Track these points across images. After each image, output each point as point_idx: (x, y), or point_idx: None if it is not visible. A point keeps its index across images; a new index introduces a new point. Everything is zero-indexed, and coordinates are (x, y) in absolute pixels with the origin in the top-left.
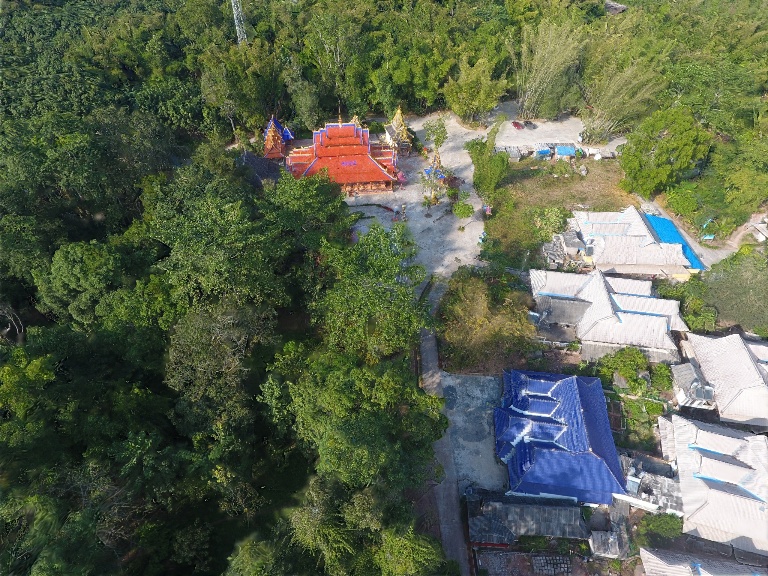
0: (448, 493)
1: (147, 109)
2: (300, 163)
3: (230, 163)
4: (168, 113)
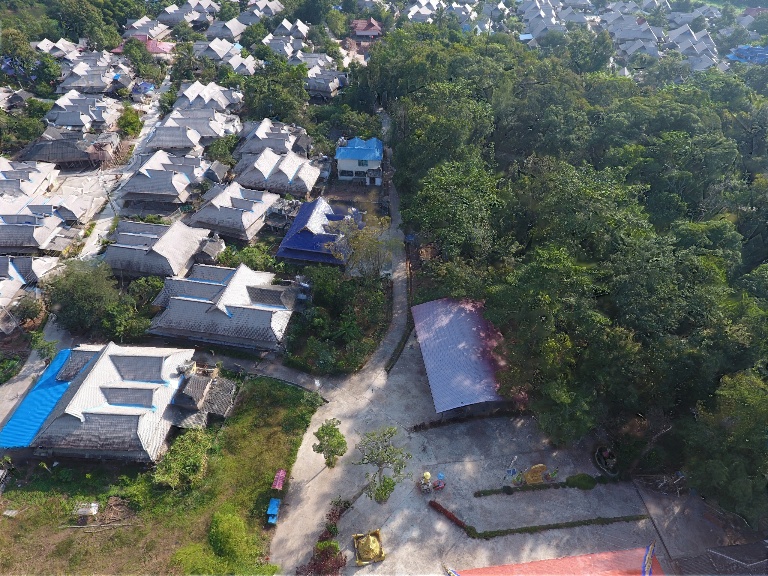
0: (396, 224)
1: None
2: None
3: None
4: None
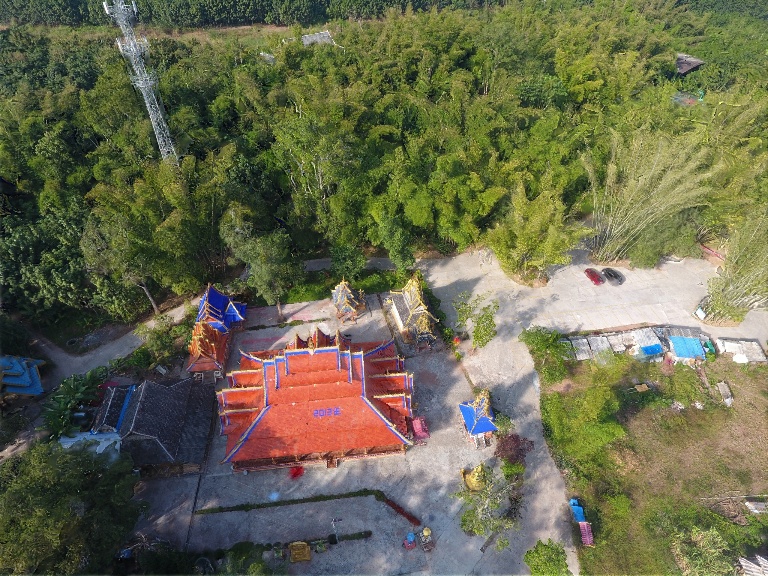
0: None
1: (1, 277)
2: (239, 411)
3: (51, 536)
4: (37, 282)
